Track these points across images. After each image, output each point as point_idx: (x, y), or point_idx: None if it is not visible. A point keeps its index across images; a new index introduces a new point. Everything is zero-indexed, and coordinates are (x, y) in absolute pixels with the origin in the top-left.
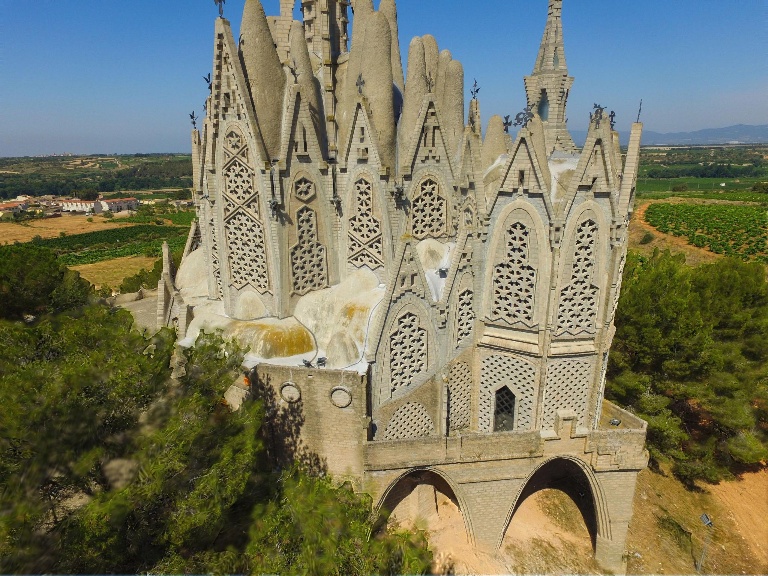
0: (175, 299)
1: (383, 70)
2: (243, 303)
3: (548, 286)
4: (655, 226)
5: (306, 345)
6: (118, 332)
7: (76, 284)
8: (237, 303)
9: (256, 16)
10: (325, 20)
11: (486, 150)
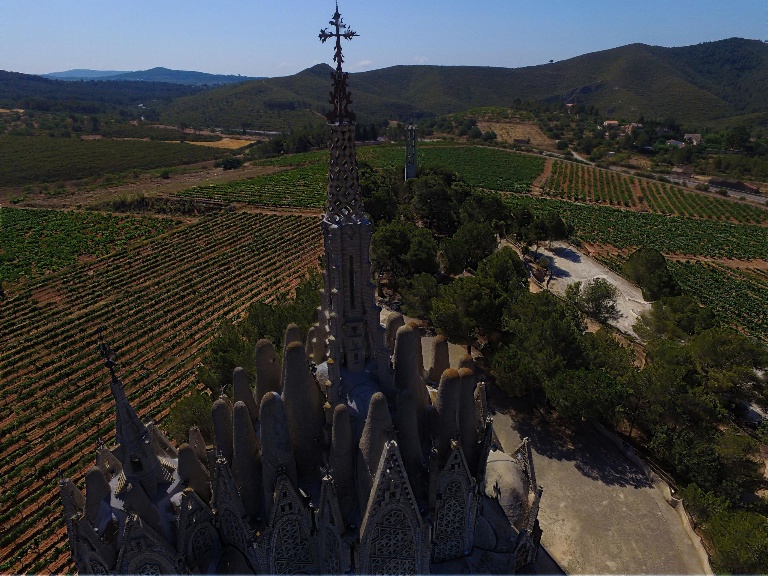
0: None
1: None
2: None
3: None
4: None
5: None
6: None
7: (712, 456)
8: None
9: None
10: None
11: None
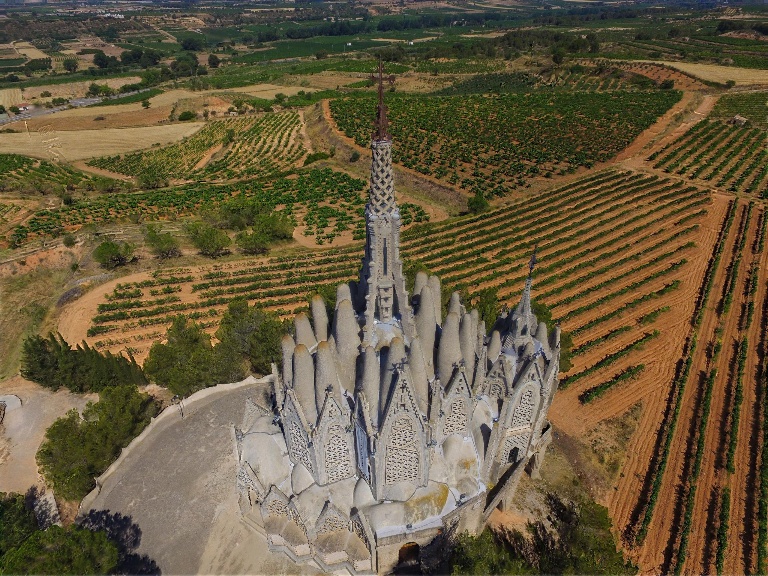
0: (332, 509)
1: (458, 340)
2: (406, 492)
3: (538, 408)
4: (351, 137)
5: (447, 492)
6: (484, 574)
7: None
8: (400, 493)
9: (403, 349)
10: (410, 314)
11: (494, 349)
